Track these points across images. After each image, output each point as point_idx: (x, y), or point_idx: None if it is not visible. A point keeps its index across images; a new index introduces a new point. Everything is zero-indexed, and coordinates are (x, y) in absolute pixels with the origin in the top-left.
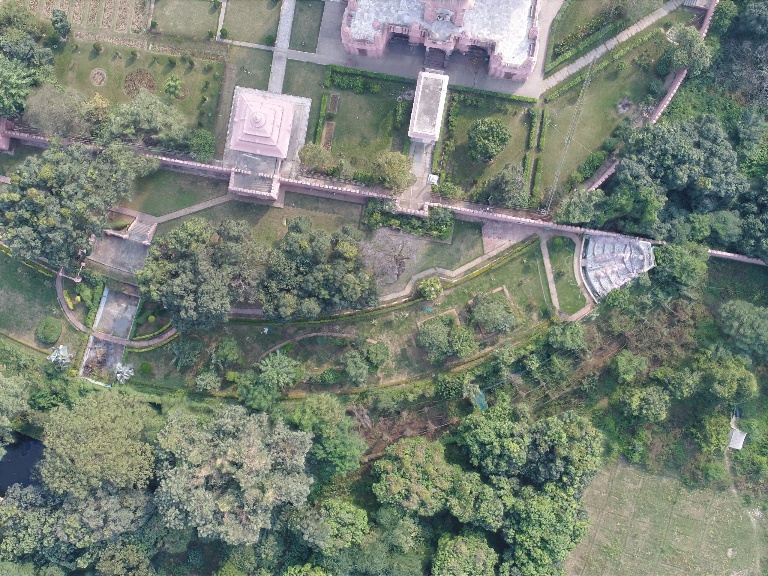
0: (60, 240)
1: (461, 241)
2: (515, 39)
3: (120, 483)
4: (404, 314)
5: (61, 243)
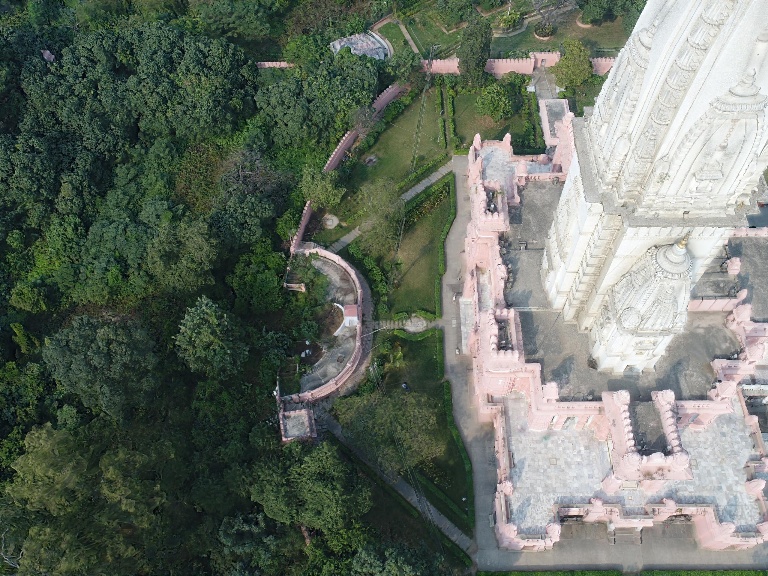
0: None
1: (493, 55)
2: (496, 165)
3: None
4: (525, 8)
5: None
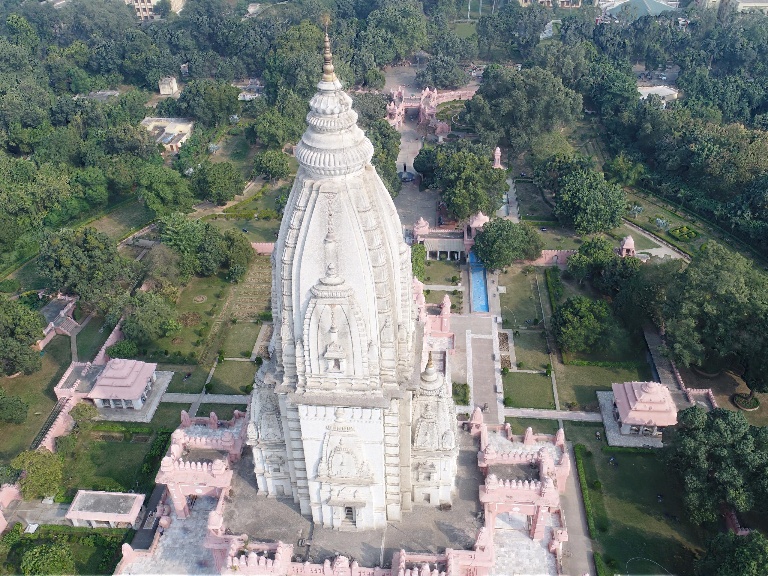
0: (43, 252)
1: None
2: (152, 573)
3: None
4: None
5: (43, 255)
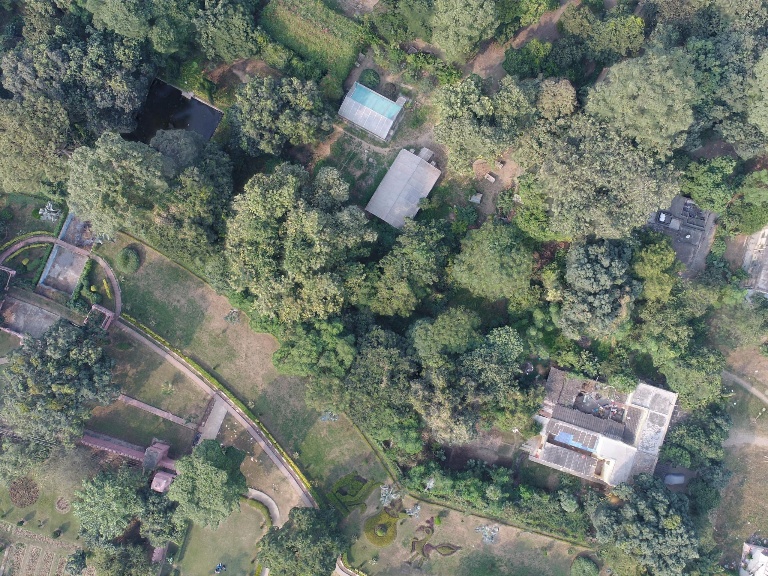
0: None
1: None
2: None
3: (0, 103)
4: None
5: None
